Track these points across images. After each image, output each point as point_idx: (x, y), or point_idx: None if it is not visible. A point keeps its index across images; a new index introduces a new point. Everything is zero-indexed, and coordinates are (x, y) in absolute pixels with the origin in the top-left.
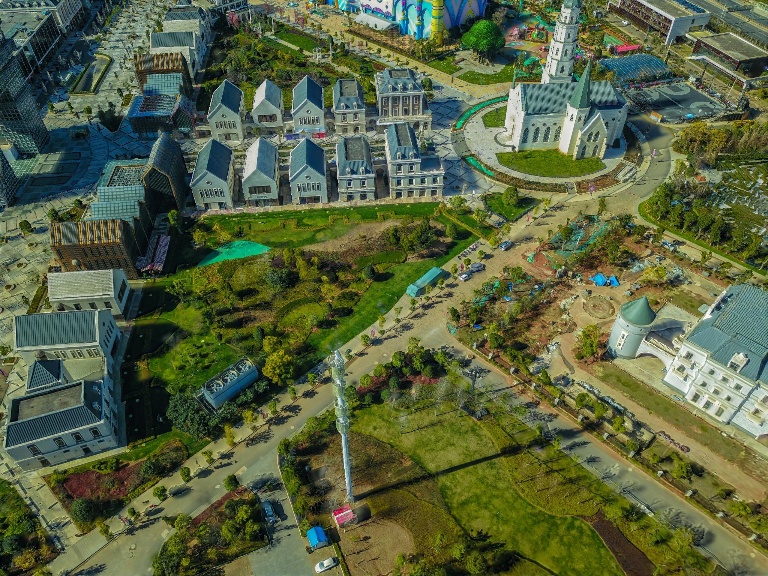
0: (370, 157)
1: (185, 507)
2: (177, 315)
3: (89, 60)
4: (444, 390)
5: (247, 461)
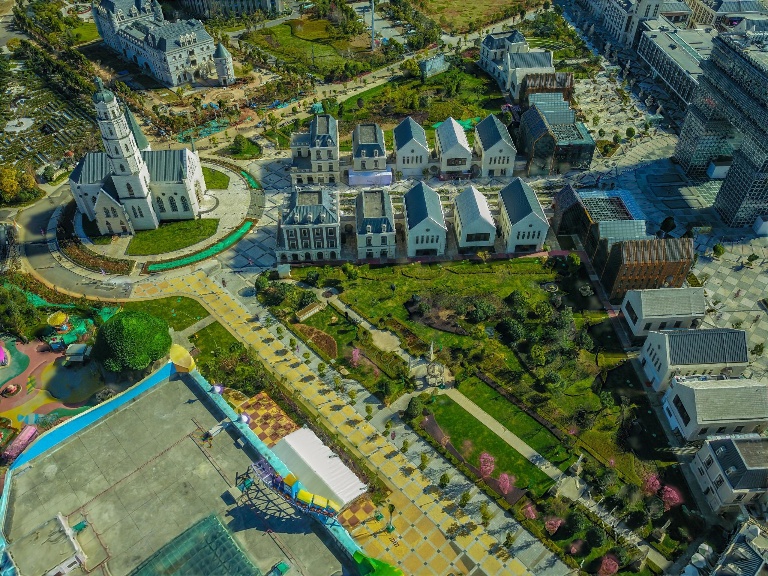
0: None
1: None
2: None
3: None
4: None
5: None
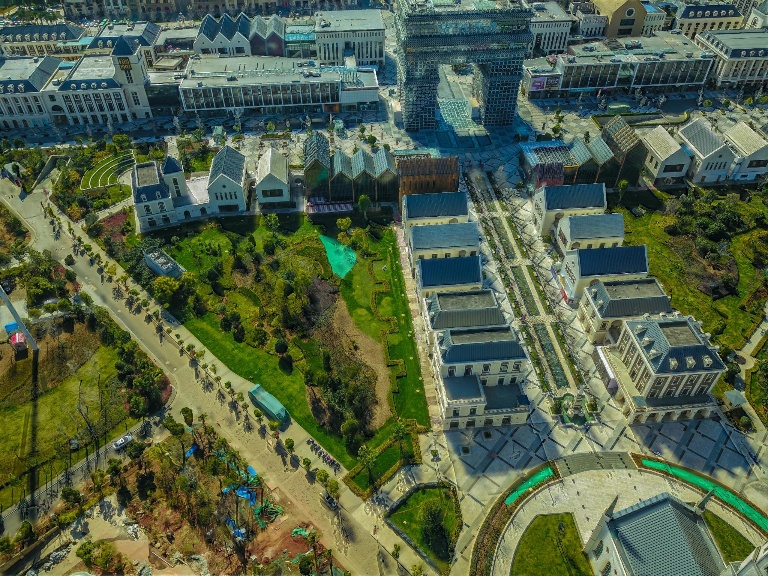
0: (471, 325)
1: (78, 265)
2: (260, 234)
3: (673, 112)
4: (91, 399)
5: (100, 290)
